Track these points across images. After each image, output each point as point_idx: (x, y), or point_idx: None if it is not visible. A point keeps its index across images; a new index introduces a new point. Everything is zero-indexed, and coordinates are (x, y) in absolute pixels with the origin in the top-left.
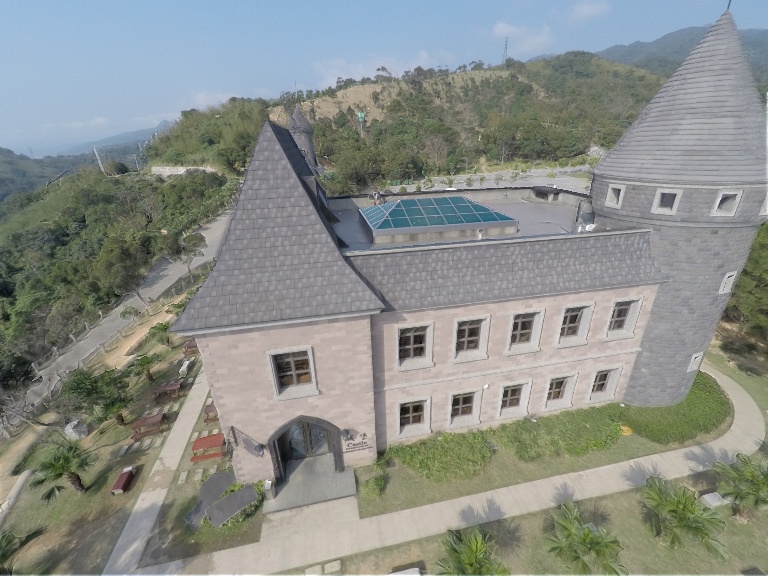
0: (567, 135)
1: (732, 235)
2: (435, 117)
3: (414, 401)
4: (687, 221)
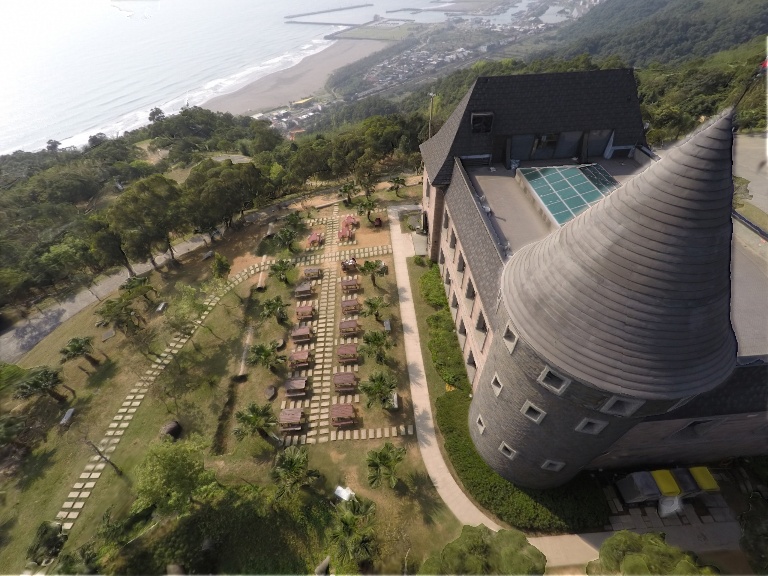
0: None
1: None
2: None
3: None
4: None
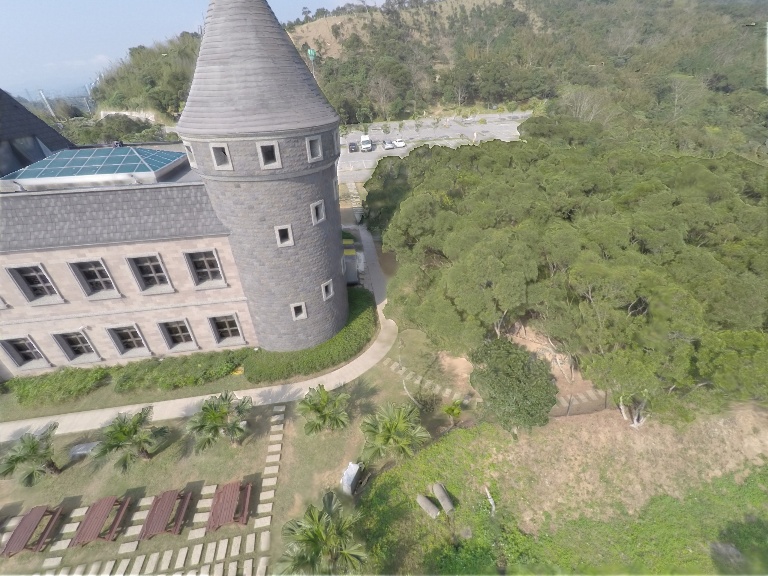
0: (532, 74)
1: (256, 189)
2: (395, 54)
3: (14, 338)
4: (208, 175)
